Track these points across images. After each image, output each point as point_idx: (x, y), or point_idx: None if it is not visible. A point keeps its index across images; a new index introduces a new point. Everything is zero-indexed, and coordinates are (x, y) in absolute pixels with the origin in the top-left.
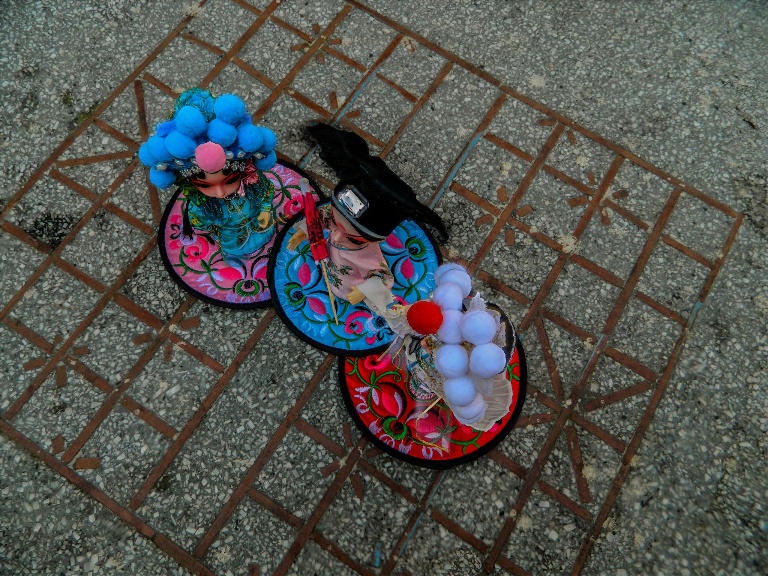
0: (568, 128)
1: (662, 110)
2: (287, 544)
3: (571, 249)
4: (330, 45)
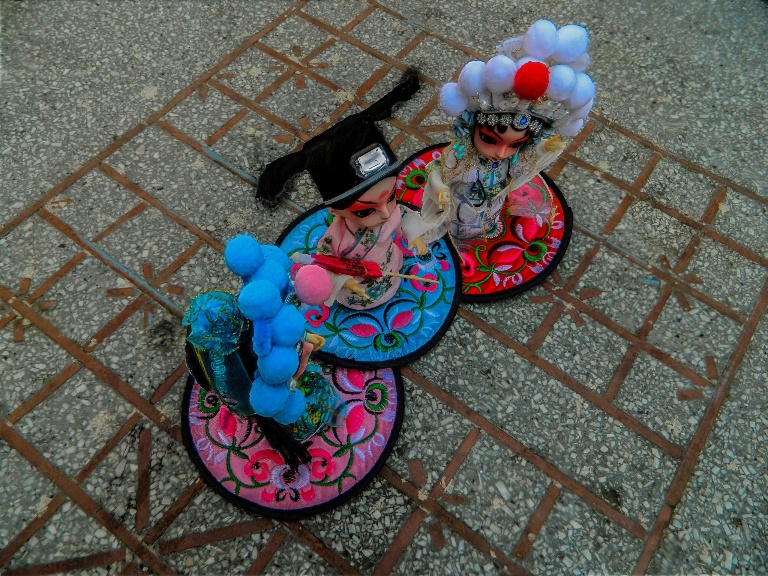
0: (214, 77)
1: (211, 6)
2: (654, 362)
3: (350, 95)
4: (29, 292)
